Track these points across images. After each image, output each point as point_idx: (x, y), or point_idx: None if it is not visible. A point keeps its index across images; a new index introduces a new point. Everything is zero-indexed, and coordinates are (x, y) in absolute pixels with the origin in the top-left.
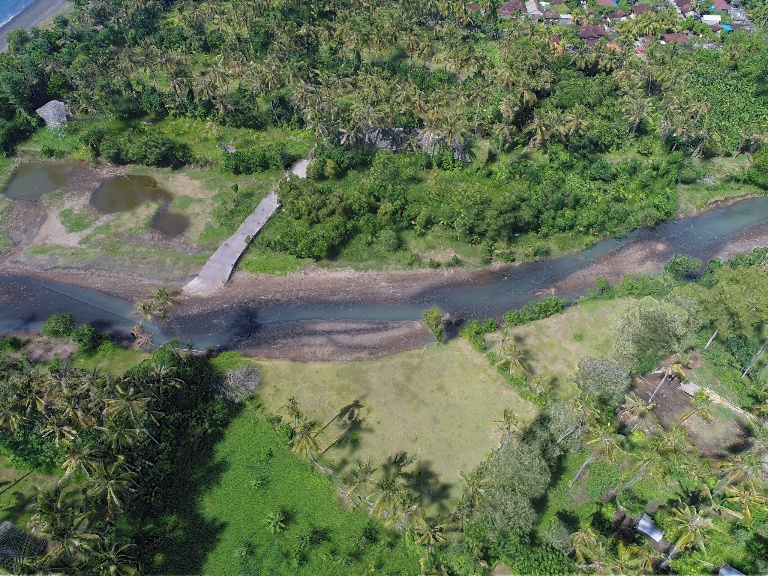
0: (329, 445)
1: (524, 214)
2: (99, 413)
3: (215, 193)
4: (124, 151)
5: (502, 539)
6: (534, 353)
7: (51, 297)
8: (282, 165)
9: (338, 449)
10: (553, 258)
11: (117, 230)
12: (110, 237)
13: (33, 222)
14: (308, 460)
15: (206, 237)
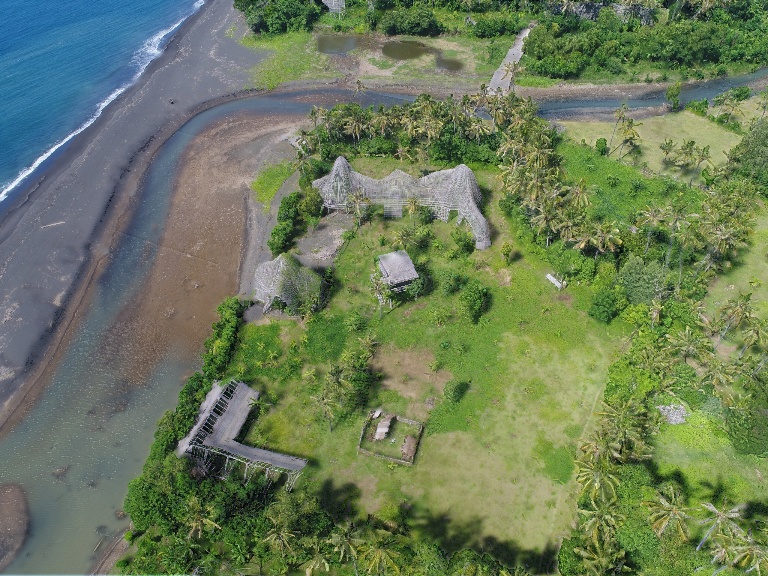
0: (624, 155)
1: (714, 42)
2: (509, 113)
3: (472, 48)
4: (399, 23)
5: (759, 175)
6: (738, 116)
7: (392, 100)
8: (518, 29)
9: (631, 156)
10: (730, 77)
11: (415, 67)
12: (412, 71)
13: (352, 65)
14: (614, 160)
15: (480, 69)
